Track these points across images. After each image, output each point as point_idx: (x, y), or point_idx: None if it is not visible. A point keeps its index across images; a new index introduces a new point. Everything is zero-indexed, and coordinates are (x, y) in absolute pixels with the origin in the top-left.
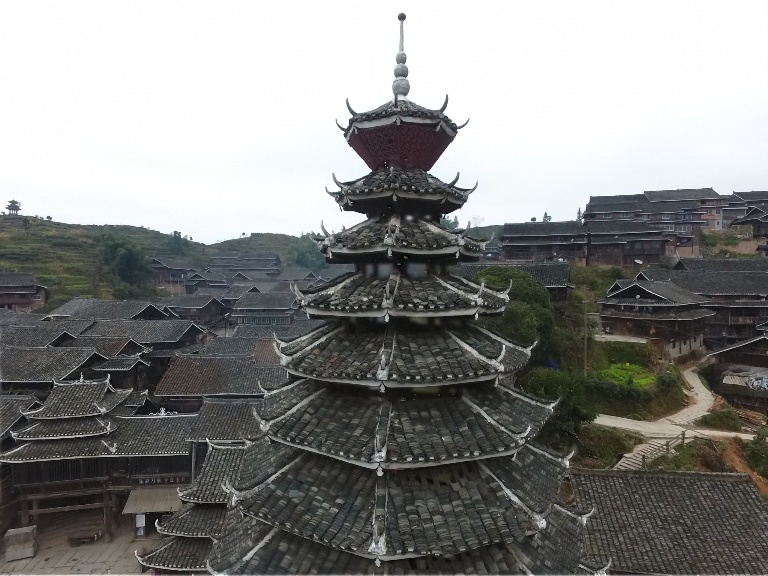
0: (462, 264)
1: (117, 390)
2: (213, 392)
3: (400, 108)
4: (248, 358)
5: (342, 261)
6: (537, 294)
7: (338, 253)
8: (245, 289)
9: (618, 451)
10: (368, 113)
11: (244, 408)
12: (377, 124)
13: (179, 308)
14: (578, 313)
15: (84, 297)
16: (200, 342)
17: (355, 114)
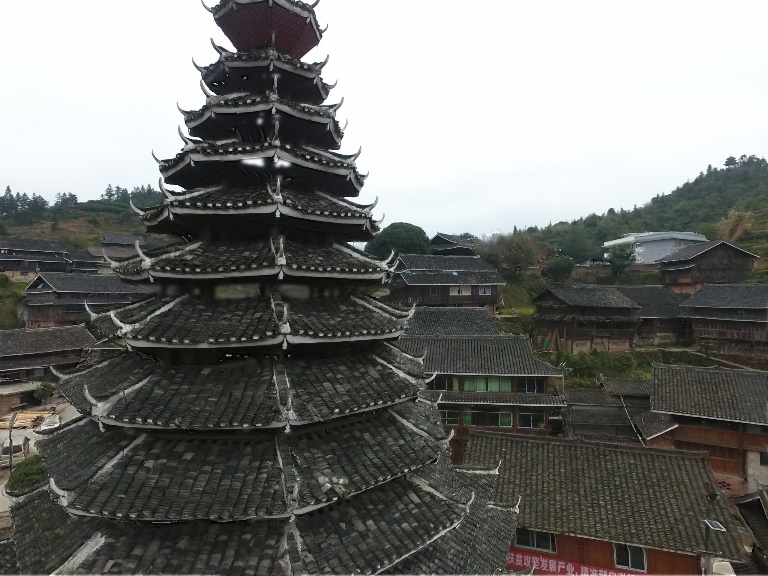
0: None
1: None
2: None
3: None
4: None
5: (323, 142)
6: None
7: None
8: None
9: None
10: None
11: None
12: None
13: None
14: None
15: None
16: None
17: None
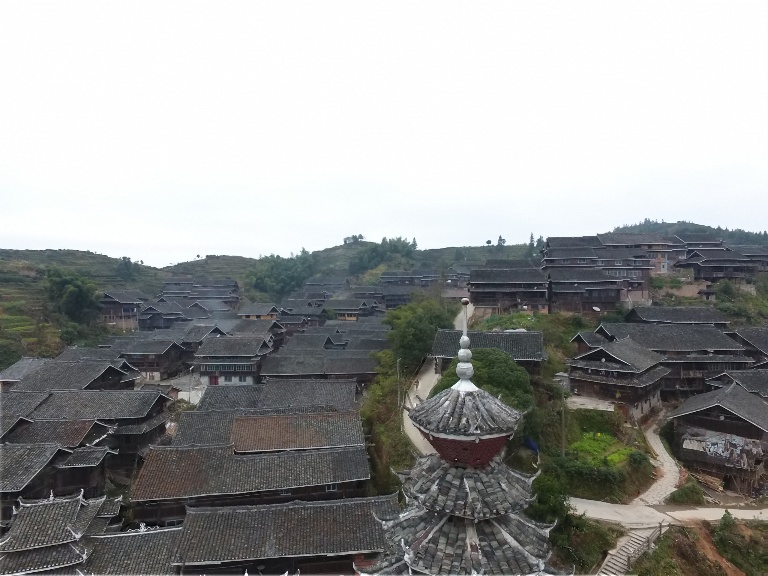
0: (439, 330)
1: (89, 501)
2: (194, 493)
3: (475, 419)
4: (228, 447)
5: None
6: (519, 380)
7: (419, 572)
8: (206, 330)
9: (603, 547)
10: (444, 423)
11: (231, 518)
12: (455, 438)
13: (136, 355)
14: (556, 394)
15: (34, 357)
16: (167, 410)
17: (431, 423)
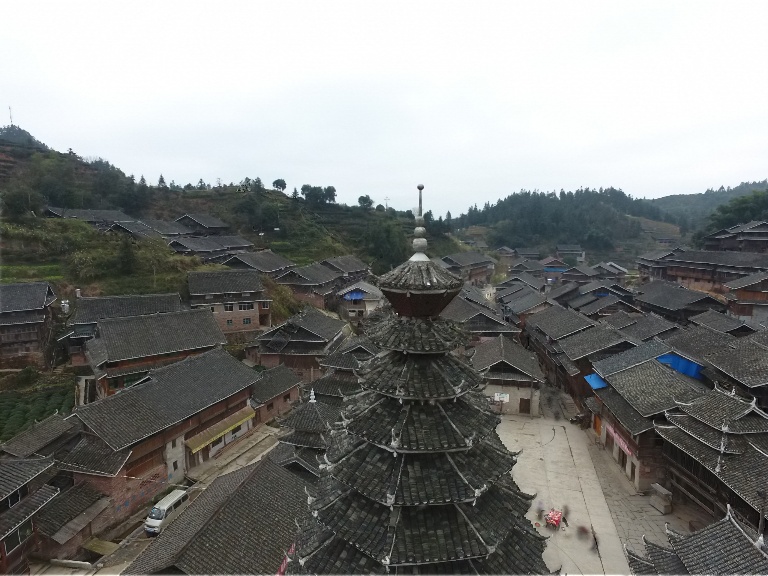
0: None
1: None
2: None
3: None
4: None
5: None
6: None
7: None
8: None
9: None
10: None
11: None
12: None
13: None
14: None
15: None
16: None
17: None
